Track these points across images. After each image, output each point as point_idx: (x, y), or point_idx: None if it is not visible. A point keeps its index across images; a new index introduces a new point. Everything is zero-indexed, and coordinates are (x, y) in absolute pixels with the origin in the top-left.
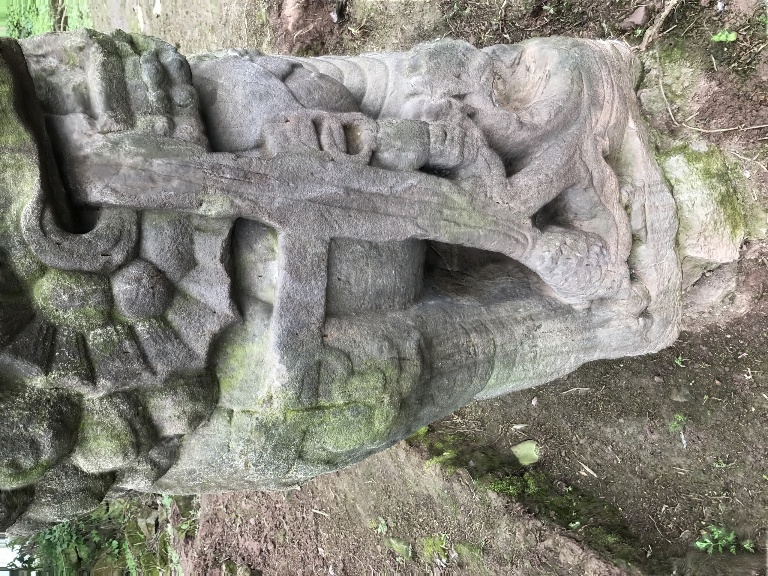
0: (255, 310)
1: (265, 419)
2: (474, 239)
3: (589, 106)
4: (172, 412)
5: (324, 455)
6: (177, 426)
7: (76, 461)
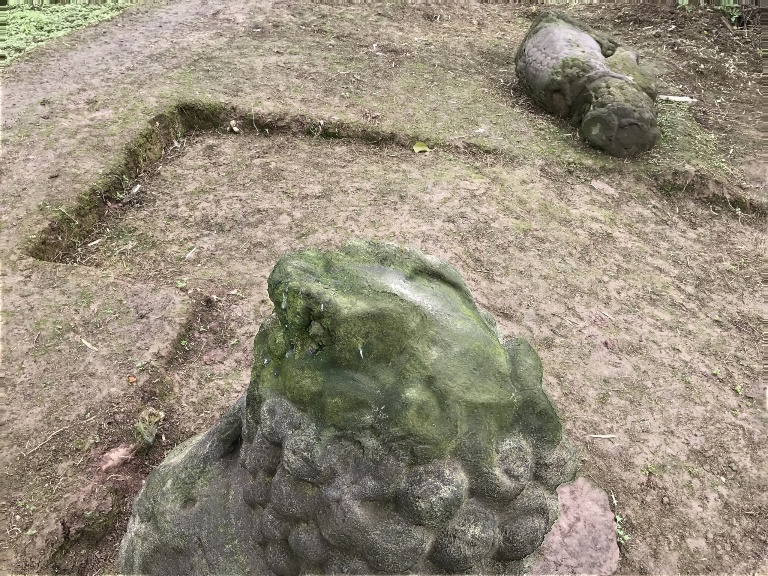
0: None
1: None
2: None
3: None
4: None
5: None
6: None
7: None
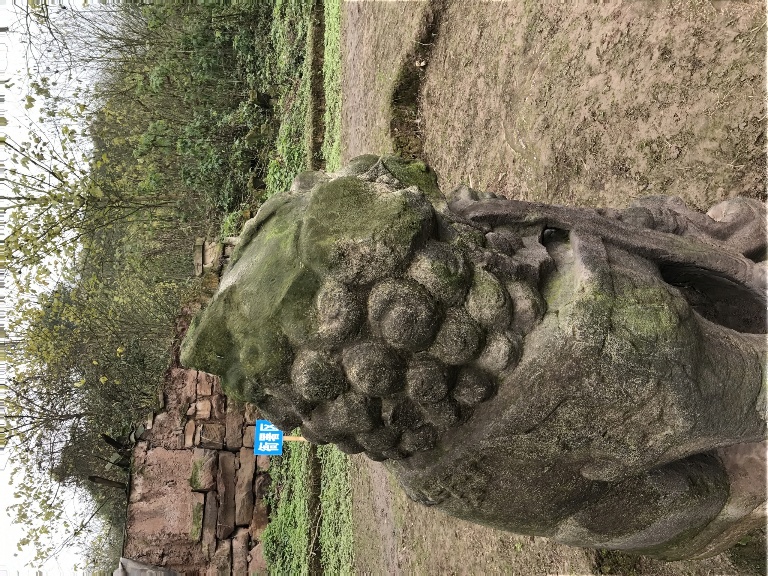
0: None
1: (581, 300)
2: (702, 258)
3: (759, 213)
4: (521, 294)
5: (628, 336)
6: (525, 303)
7: (467, 308)
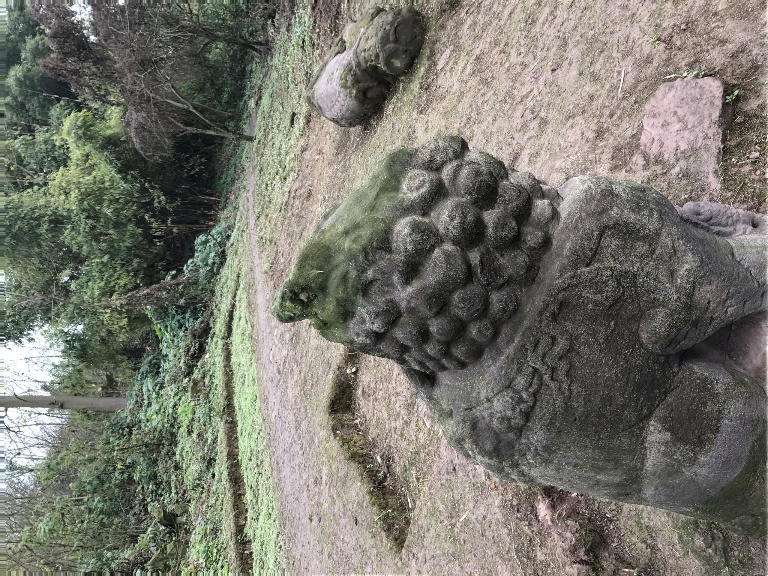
0: None
1: None
2: None
3: None
4: None
5: None
6: None
7: None
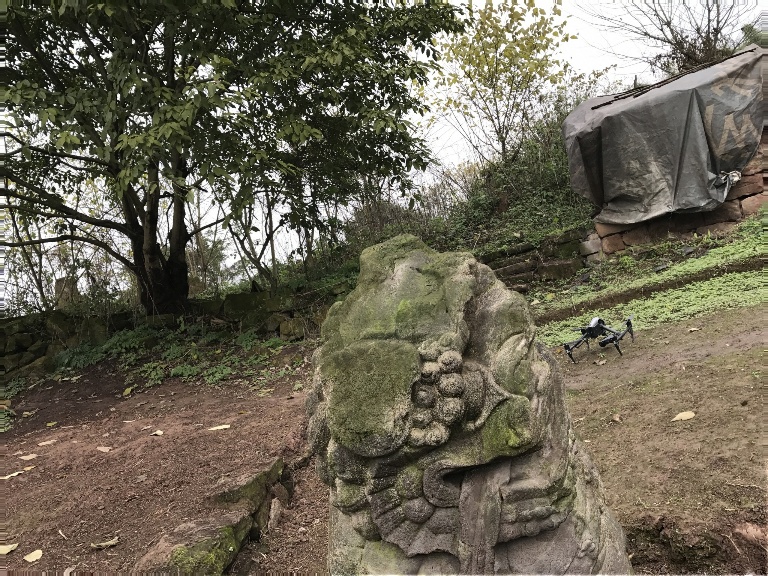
0: (414, 565)
1: (357, 569)
2: None
3: None
4: (361, 521)
5: None
6: (355, 523)
7: None
